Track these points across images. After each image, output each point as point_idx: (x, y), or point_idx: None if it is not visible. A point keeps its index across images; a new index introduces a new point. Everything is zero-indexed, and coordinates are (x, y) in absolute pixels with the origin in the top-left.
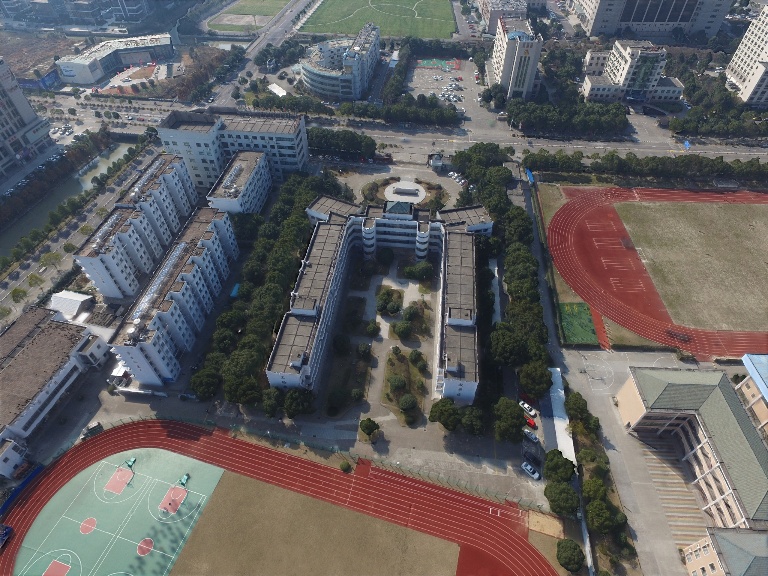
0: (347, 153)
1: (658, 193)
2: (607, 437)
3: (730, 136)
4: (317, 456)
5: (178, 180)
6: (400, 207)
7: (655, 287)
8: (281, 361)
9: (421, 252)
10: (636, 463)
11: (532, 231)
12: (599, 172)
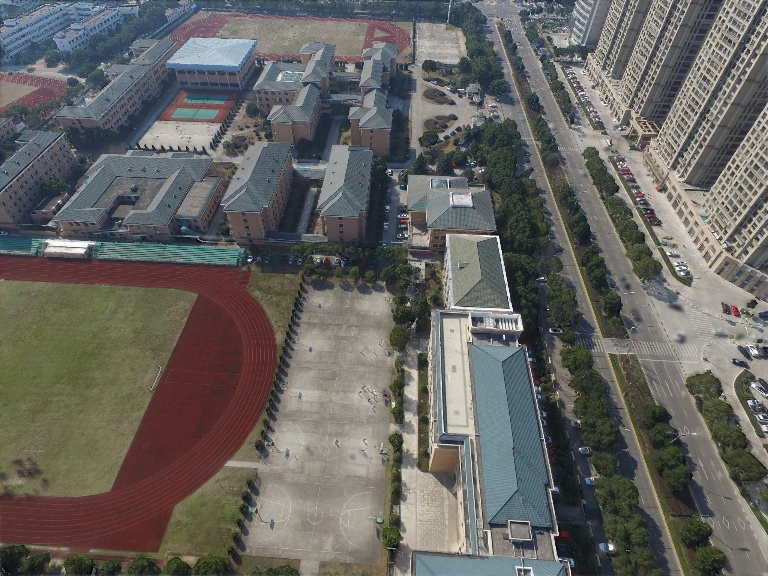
0: None
1: (261, 16)
2: None
3: None
4: (1, 72)
5: None
6: None
7: None
8: None
9: None
10: None
11: (158, 16)
12: (239, 8)
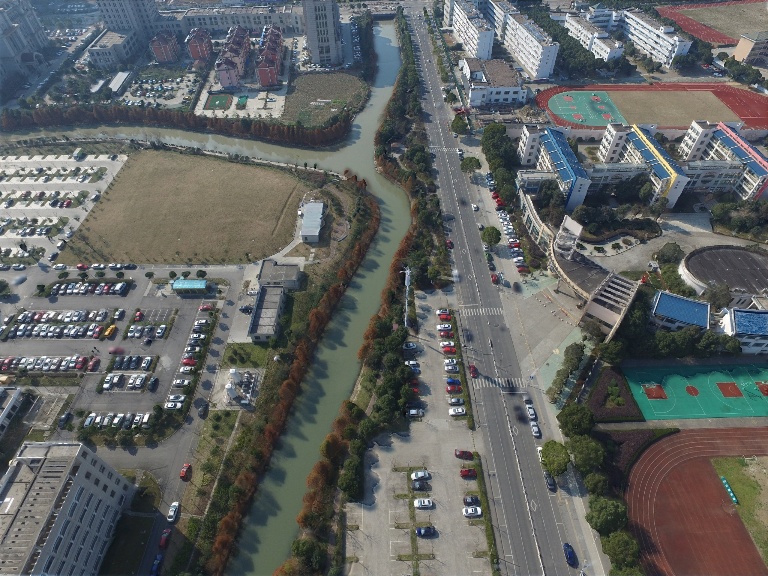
0: None
1: (693, 6)
2: None
3: None
4: None
5: None
6: (602, 5)
7: (719, 31)
8: None
9: (615, 28)
10: None
11: None
12: (659, 1)
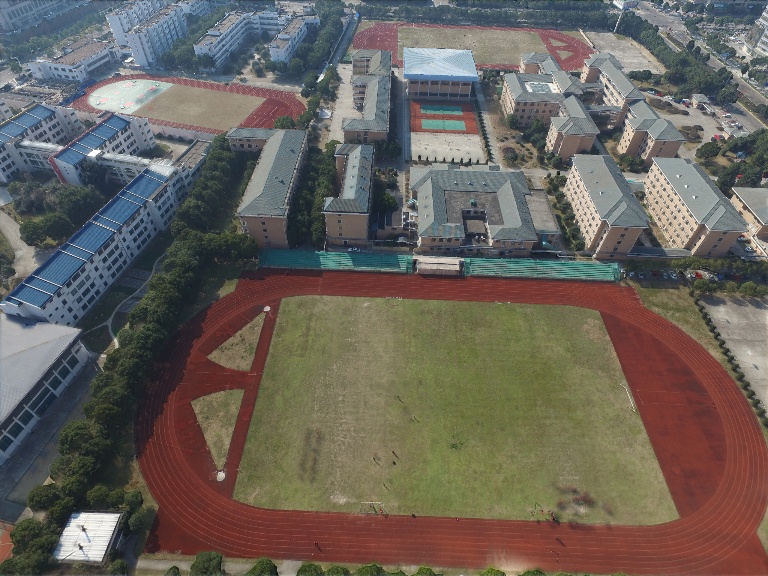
0: (258, 7)
1: (426, 25)
2: (343, 81)
3: (486, 7)
4: (215, 82)
5: (158, 1)
6: (271, 8)
7: (397, 50)
8: (201, 44)
9: None
10: (351, 86)
11: (340, 25)
12: (399, 17)
